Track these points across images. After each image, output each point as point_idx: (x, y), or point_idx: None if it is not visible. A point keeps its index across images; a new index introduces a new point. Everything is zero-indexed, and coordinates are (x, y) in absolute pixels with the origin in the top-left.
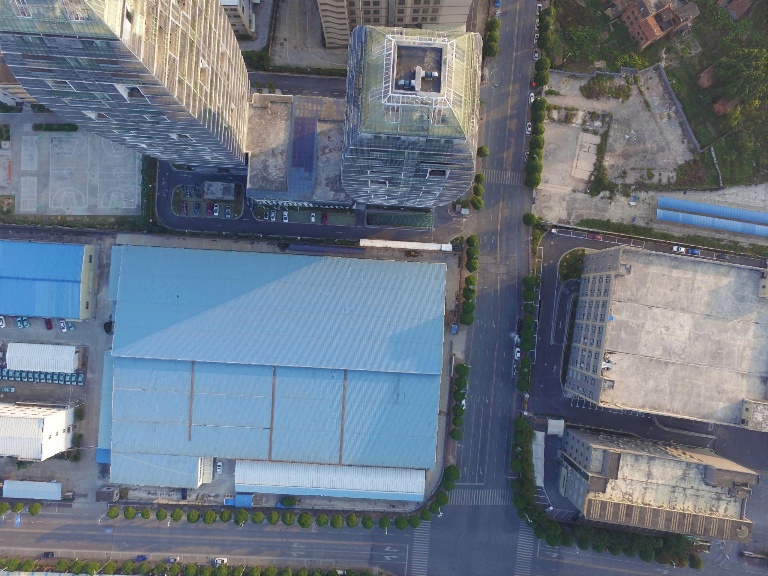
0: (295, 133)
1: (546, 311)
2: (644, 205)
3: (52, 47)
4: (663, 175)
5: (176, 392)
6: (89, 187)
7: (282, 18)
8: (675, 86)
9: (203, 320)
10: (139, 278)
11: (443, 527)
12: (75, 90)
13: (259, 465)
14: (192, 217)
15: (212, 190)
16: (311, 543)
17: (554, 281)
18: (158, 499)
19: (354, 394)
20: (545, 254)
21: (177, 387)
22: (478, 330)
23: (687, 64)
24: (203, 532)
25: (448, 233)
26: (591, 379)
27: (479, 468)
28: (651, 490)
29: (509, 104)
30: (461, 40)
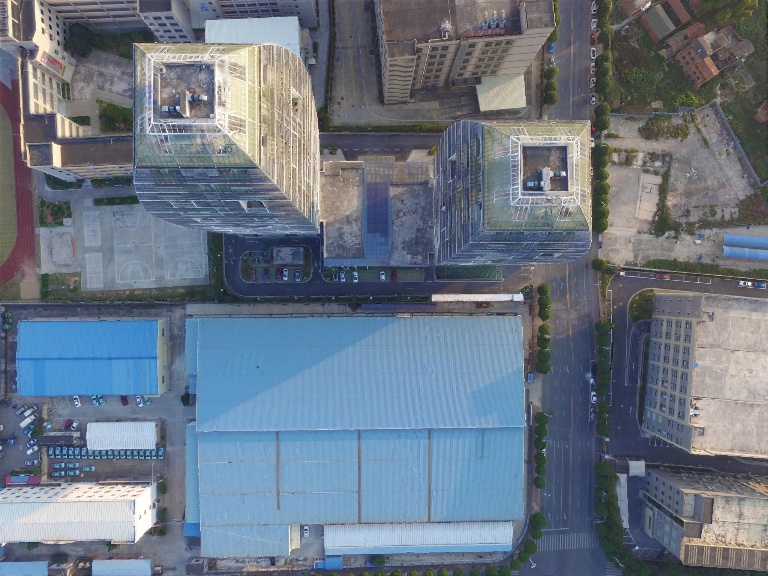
0: (368, 199)
1: (619, 353)
2: (709, 242)
3: (187, 177)
4: (726, 211)
5: (262, 462)
6: (155, 259)
7: (338, 77)
8: (733, 123)
9: (285, 389)
10: (217, 351)
11: (531, 574)
12: (196, 206)
13: (347, 527)
14: (261, 283)
15: (281, 256)
16: None
17: (625, 323)
18: (247, 567)
19: (439, 452)
20: (614, 297)
21: (263, 457)
22: (553, 376)
23: (742, 99)
24: None
25: (517, 282)
26: (677, 424)
27: (563, 513)
28: (743, 530)
29: None
30: (583, 135)
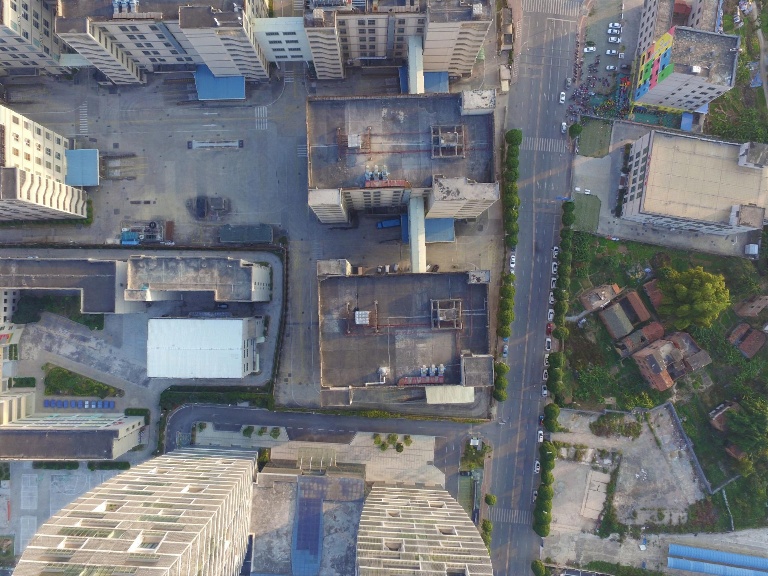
0: (300, 514)
1: None
2: (654, 548)
3: None
4: (674, 516)
5: None
6: None
7: (287, 353)
8: (686, 429)
9: None
10: None
11: None
12: None
13: None
14: None
15: None
16: None
17: None
18: None
19: None
20: None
21: None
22: None
23: (698, 400)
24: None
25: None
26: None
27: None
28: None
29: (517, 441)
30: None
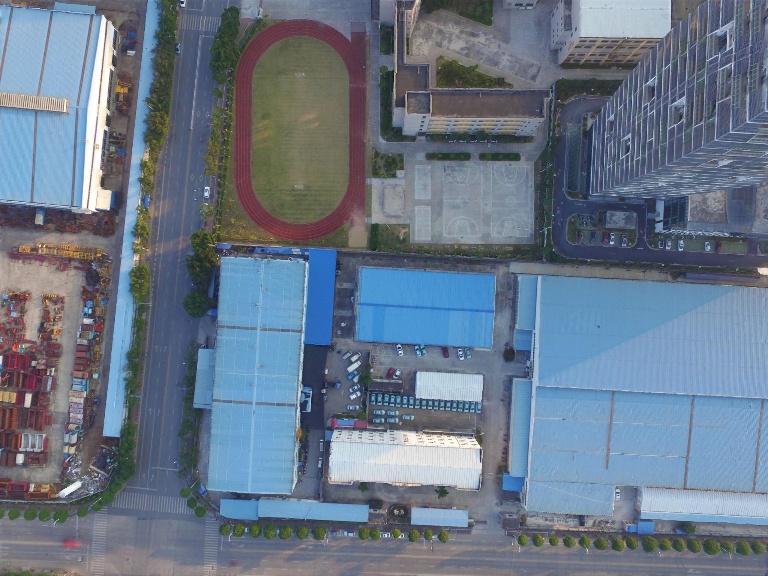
0: None
1: None
2: None
3: None
4: None
5: (595, 421)
6: (482, 216)
7: None
8: None
9: (625, 350)
10: (559, 308)
11: None
12: None
13: (665, 493)
14: (587, 246)
15: (615, 220)
16: (707, 569)
17: None
18: (556, 526)
19: None
20: None
21: (597, 416)
22: None
23: None
24: (600, 558)
25: None
26: None
27: None
28: None
29: None
30: None
